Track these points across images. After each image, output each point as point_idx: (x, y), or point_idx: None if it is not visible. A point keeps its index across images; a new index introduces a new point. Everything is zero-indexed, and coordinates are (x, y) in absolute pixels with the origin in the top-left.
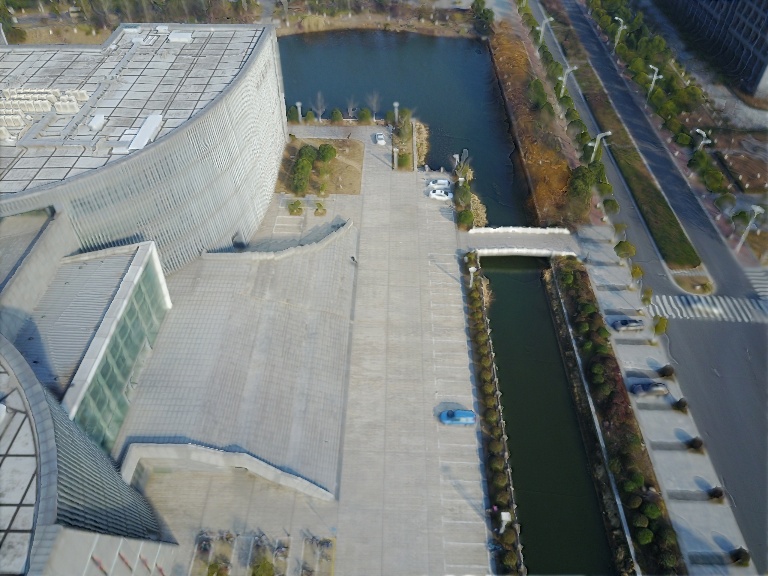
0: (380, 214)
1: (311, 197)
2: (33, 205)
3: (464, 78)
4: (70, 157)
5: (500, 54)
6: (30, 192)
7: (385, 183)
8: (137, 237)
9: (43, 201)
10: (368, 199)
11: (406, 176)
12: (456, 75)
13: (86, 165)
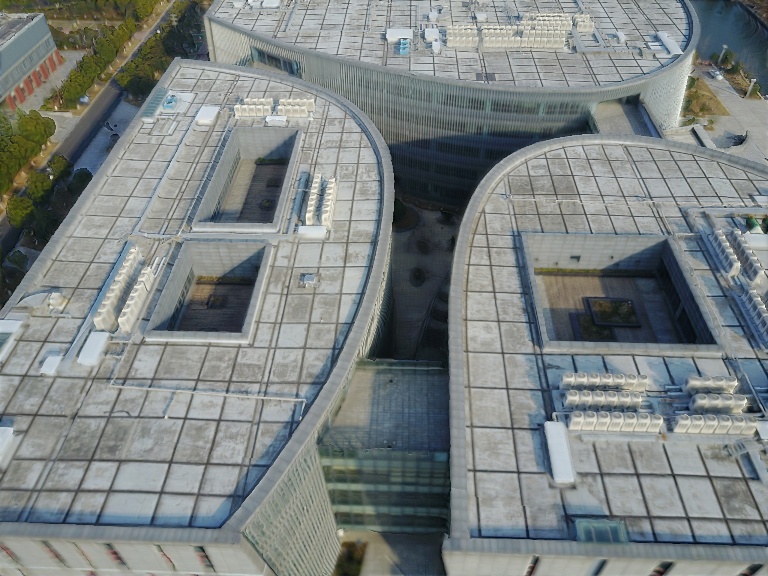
0: (759, 130)
1: (691, 117)
2: (635, 91)
3: (720, 34)
4: (628, 60)
5: (761, 11)
6: (640, 79)
7: (744, 108)
8: (660, 126)
9: (641, 88)
10: (740, 119)
11: (757, 103)
12: (713, 31)
13: (649, 65)
